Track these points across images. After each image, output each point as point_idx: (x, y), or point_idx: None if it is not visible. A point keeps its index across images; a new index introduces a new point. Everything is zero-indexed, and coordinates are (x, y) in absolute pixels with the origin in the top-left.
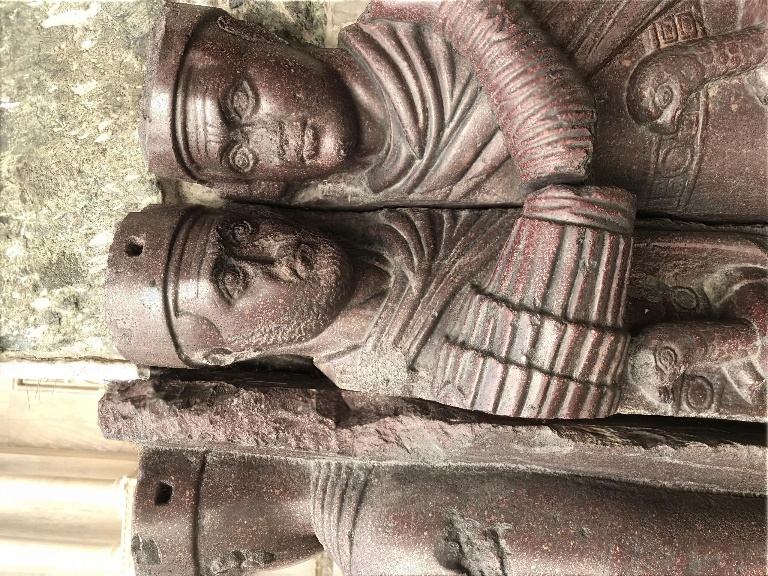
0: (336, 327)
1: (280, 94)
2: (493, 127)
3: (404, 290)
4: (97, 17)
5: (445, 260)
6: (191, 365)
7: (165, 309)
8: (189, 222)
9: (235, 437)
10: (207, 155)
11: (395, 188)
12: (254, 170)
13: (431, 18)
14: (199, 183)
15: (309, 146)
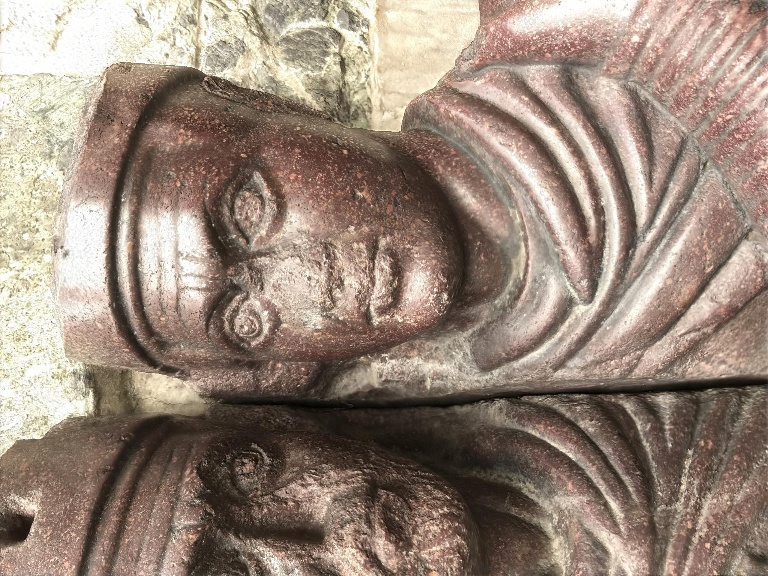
0: None
1: (325, 192)
2: (737, 233)
3: None
4: (1, 114)
5: (675, 502)
6: None
7: None
8: (139, 455)
9: None
10: (179, 317)
11: (528, 361)
12: (270, 342)
13: (608, 41)
14: (162, 372)
15: (384, 288)
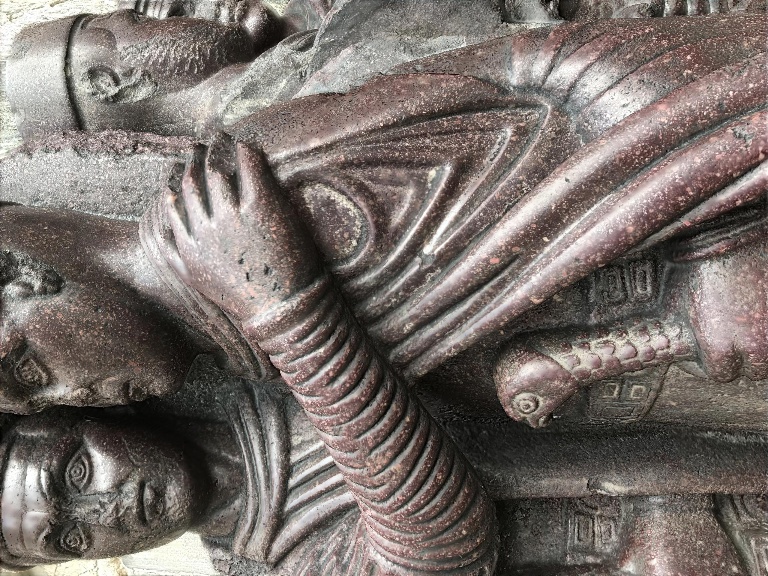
0: (231, 68)
1: None
2: None
3: None
4: None
5: None
6: (71, 97)
7: (75, 22)
8: None
9: (84, 149)
10: None
11: None
12: None
13: None
14: None
15: (240, 6)
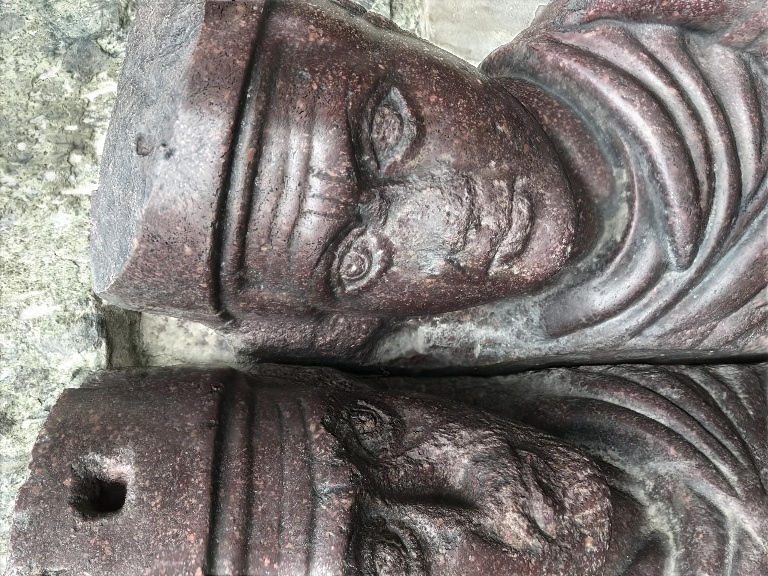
0: None
1: (468, 120)
2: None
3: (727, 540)
4: None
5: None
6: None
7: None
8: (241, 409)
9: None
10: (287, 248)
11: (604, 328)
12: (369, 288)
13: (744, 6)
14: (214, 320)
15: (519, 233)
